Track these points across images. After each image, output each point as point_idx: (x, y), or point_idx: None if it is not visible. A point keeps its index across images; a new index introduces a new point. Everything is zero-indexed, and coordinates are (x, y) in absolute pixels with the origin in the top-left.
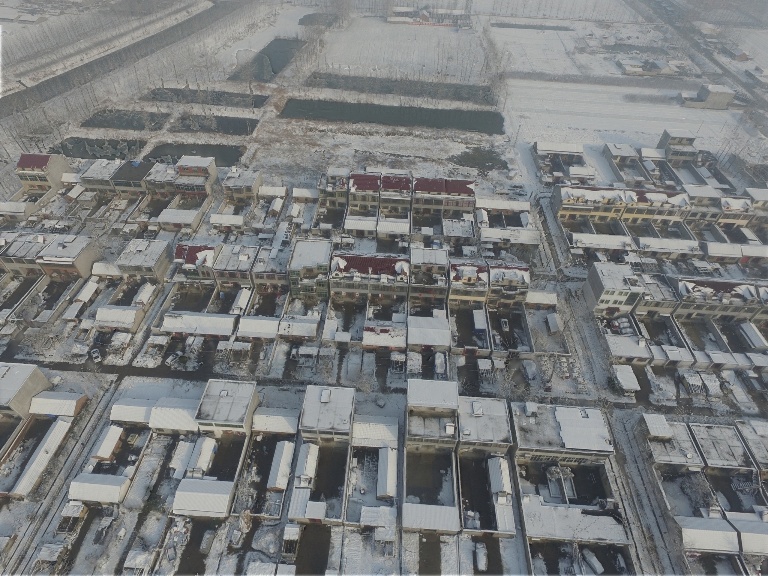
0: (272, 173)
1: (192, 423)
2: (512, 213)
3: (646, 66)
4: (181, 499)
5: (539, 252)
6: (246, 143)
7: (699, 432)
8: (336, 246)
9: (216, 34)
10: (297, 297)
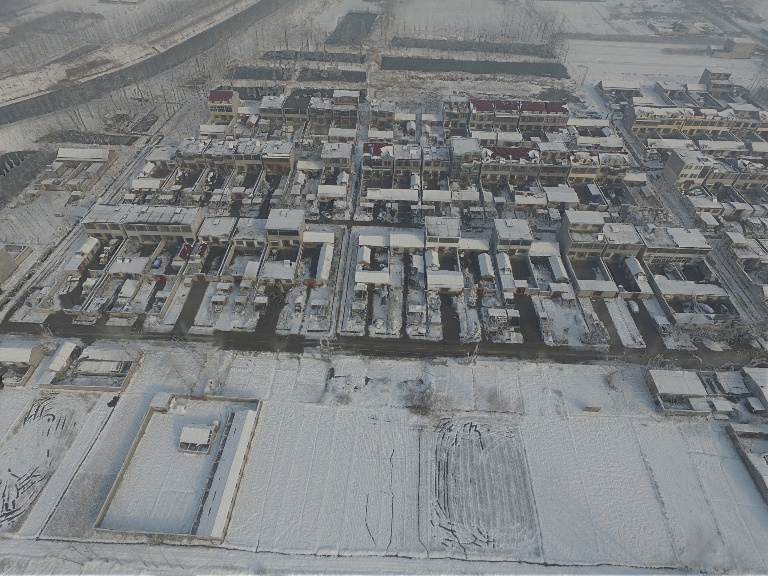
0: (396, 107)
1: (420, 243)
2: (595, 129)
3: (675, 27)
4: (432, 278)
5: None
6: (365, 87)
7: (765, 243)
8: None
9: (300, 9)
10: (454, 180)
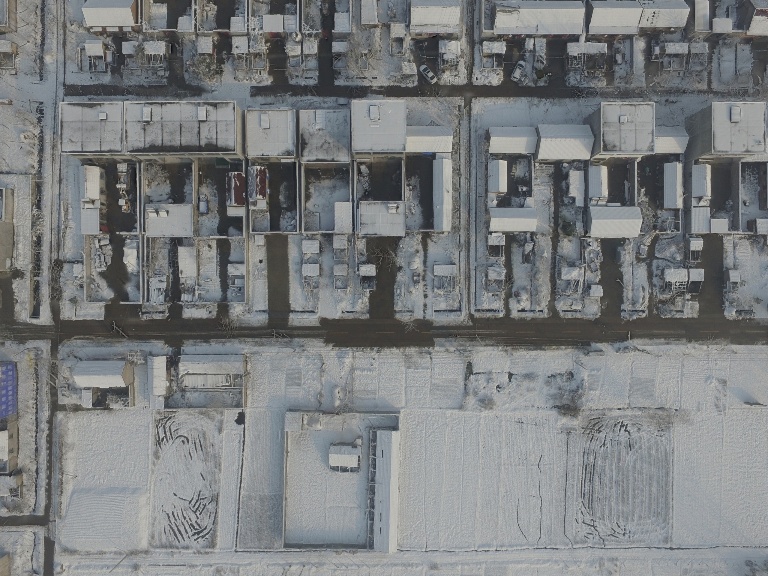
0: None
1: (584, 152)
2: None
3: None
4: (598, 226)
5: None
6: None
7: None
8: None
9: None
10: None
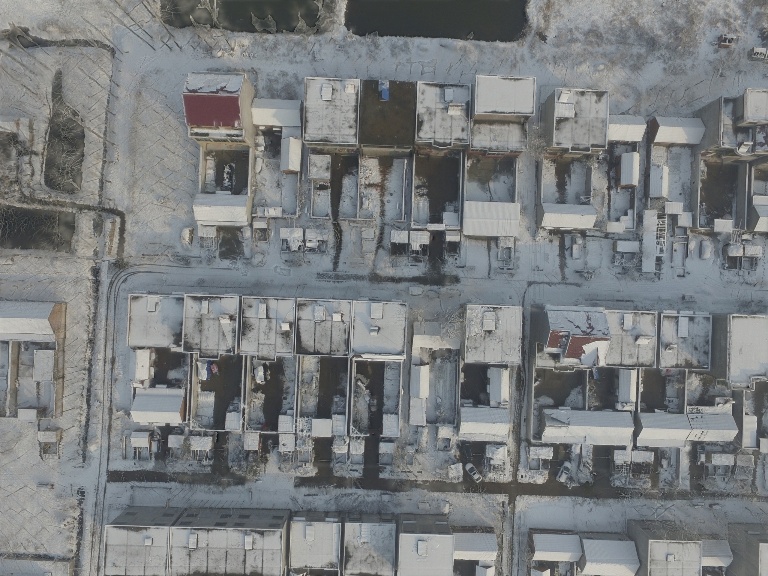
0: (595, 59)
1: (629, 573)
2: None
3: None
4: None
5: None
6: None
7: None
8: (731, 258)
9: None
10: None
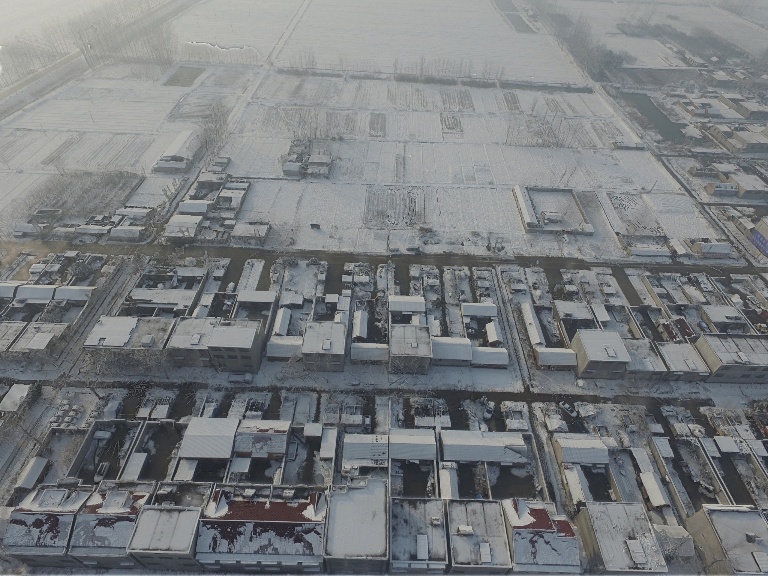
0: None
1: (435, 338)
2: None
3: None
4: None
5: None
6: None
7: (5, 344)
8: None
9: None
10: None
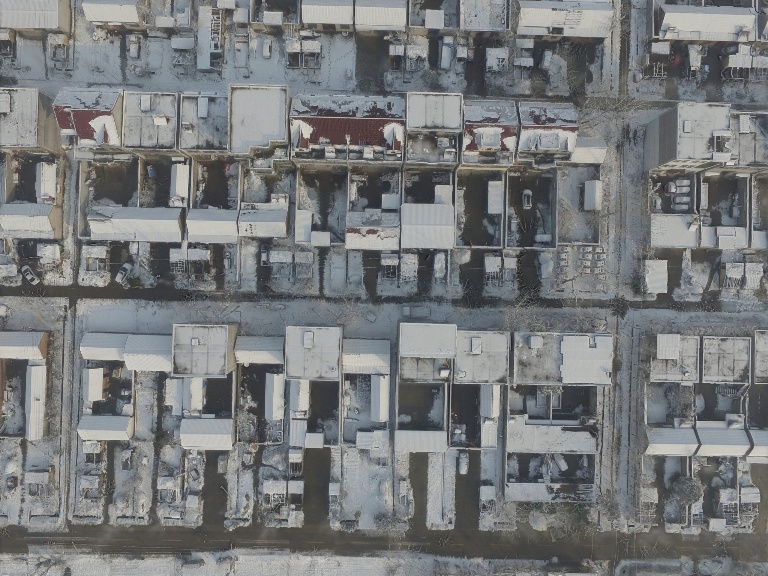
0: None
1: None
2: None
3: None
4: (187, 440)
5: (602, 50)
6: None
7: (710, 346)
8: (294, 56)
9: None
10: None
